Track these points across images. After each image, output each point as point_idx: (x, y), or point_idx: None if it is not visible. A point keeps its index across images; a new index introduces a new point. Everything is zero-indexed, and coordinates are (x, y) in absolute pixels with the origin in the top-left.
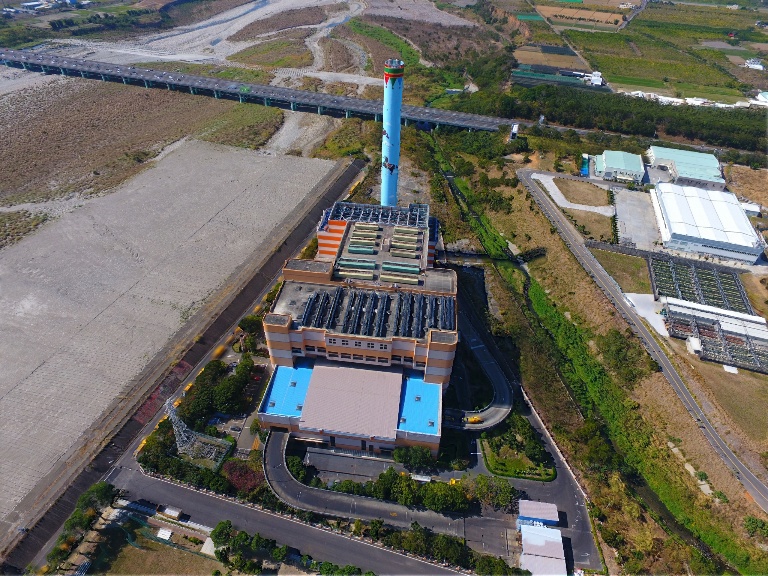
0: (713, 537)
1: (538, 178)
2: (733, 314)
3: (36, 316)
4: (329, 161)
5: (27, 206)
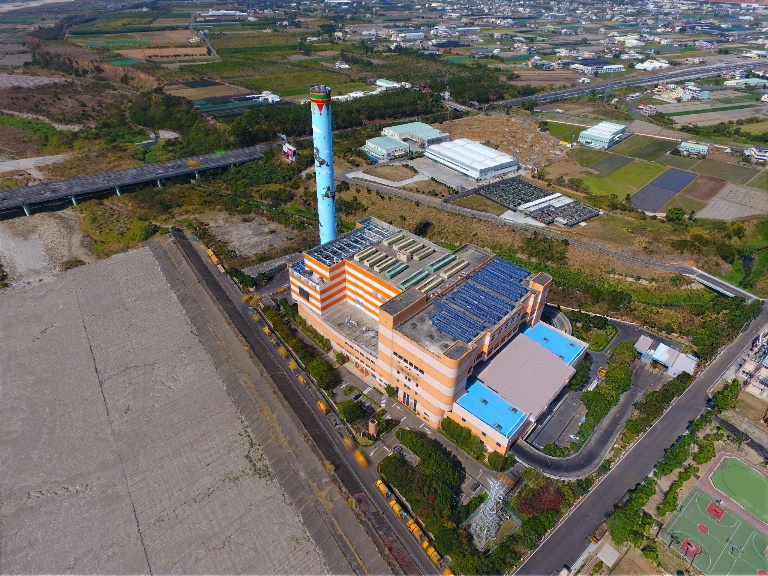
0: (673, 299)
1: (354, 176)
2: (549, 198)
3: None
4: (137, 250)
5: None
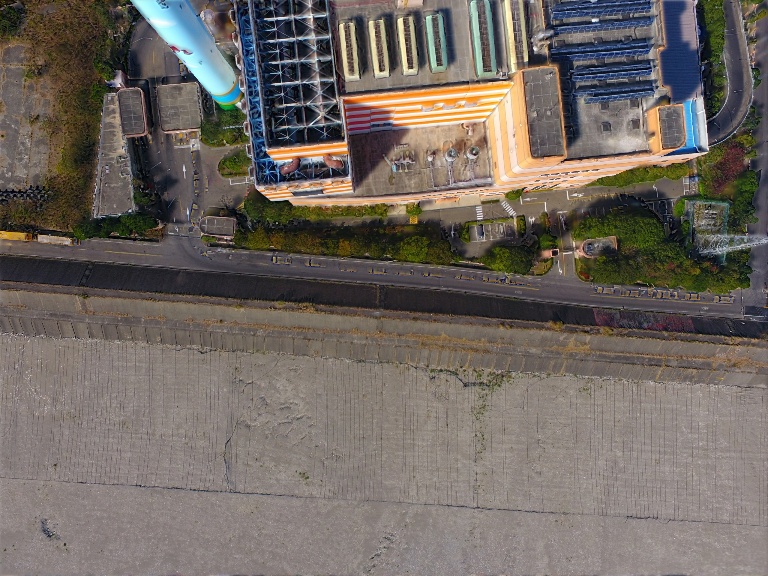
0: None
1: None
2: None
3: None
4: None
5: None
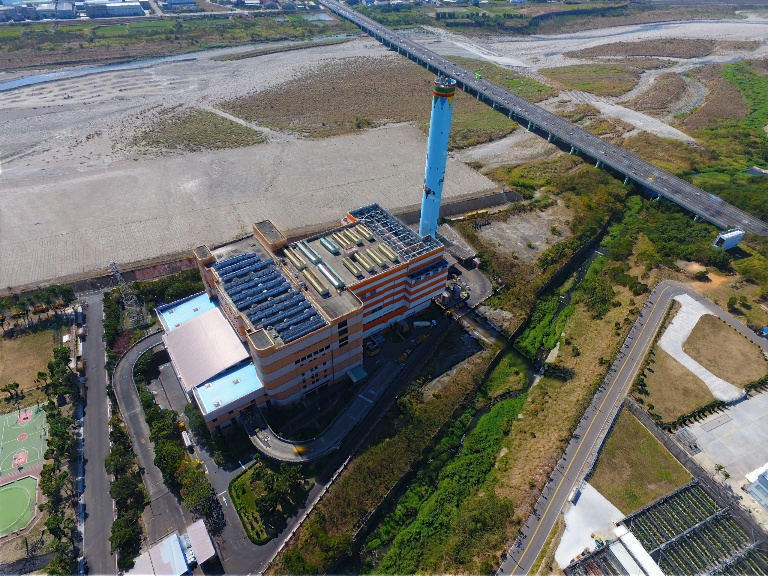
0: None
1: (683, 302)
2: None
3: (185, 192)
4: (491, 183)
5: (266, 130)
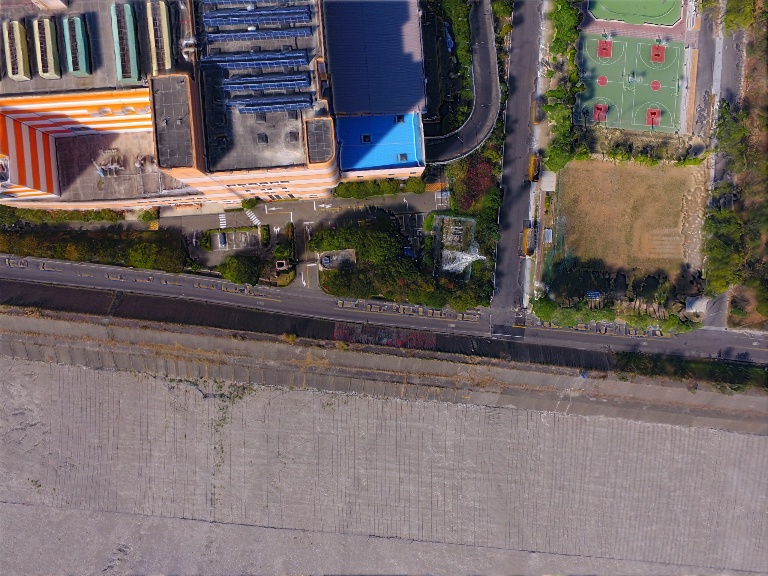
0: None
1: None
2: None
3: None
4: None
5: None
